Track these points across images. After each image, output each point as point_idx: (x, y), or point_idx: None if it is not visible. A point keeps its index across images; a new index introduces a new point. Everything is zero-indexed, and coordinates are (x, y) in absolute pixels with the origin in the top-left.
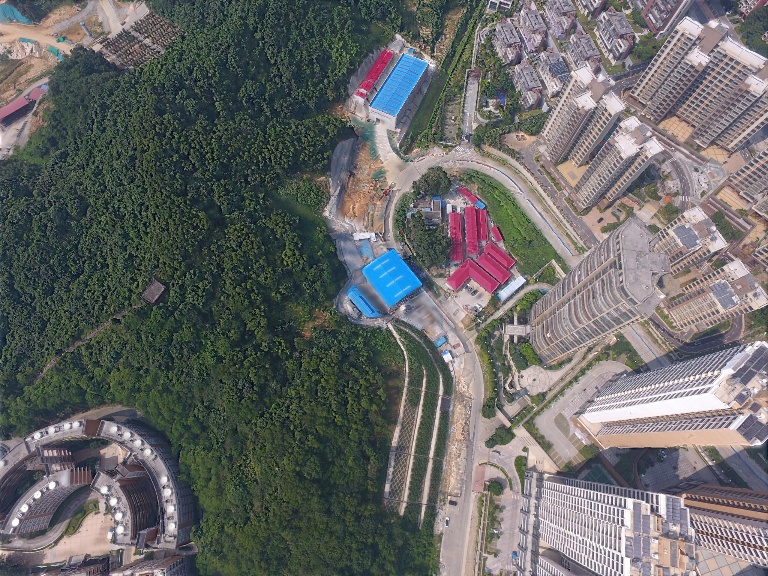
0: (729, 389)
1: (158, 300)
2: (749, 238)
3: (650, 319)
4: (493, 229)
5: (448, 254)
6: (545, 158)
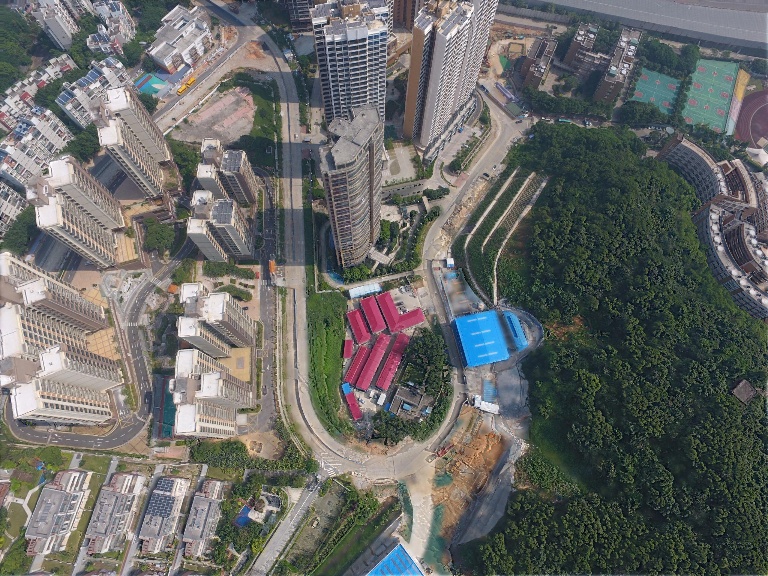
0: (372, 26)
1: None
2: (149, 209)
3: (272, 206)
4: (349, 356)
5: None
6: None
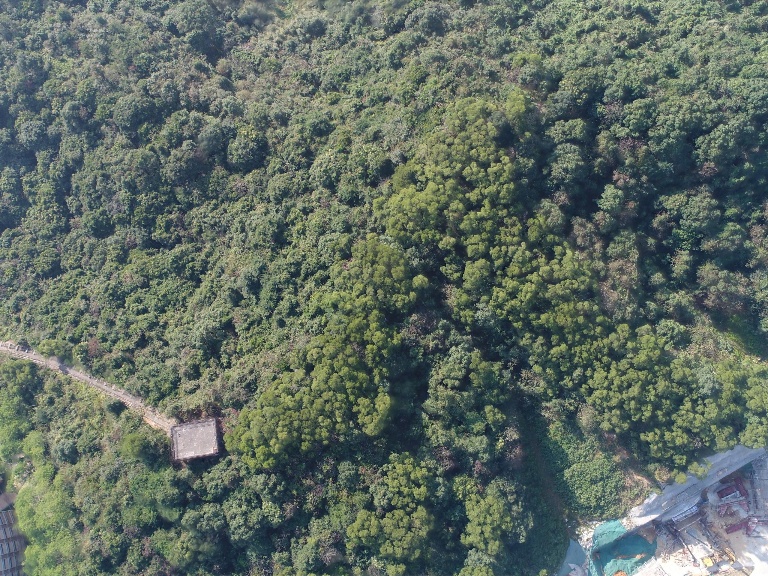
0: None
1: (189, 458)
2: None
3: None
4: None
5: None
6: None
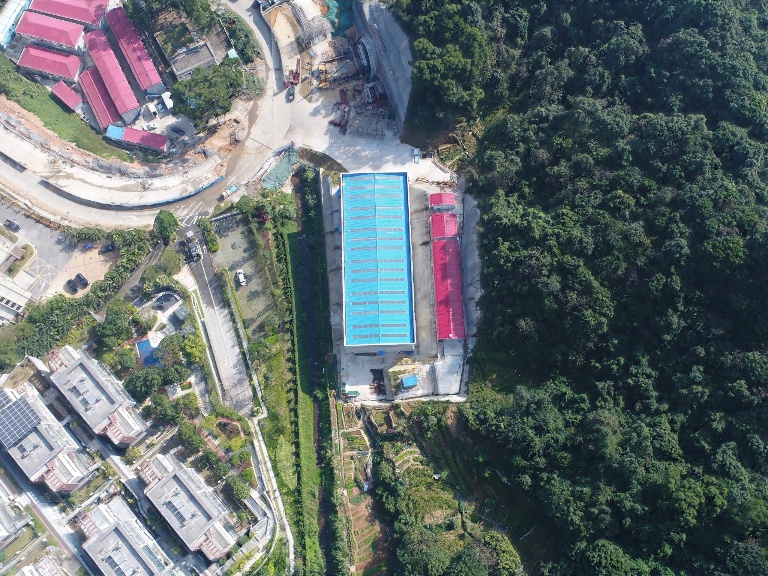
0: None
1: None
2: None
3: None
4: (76, 100)
5: (138, 27)
6: None
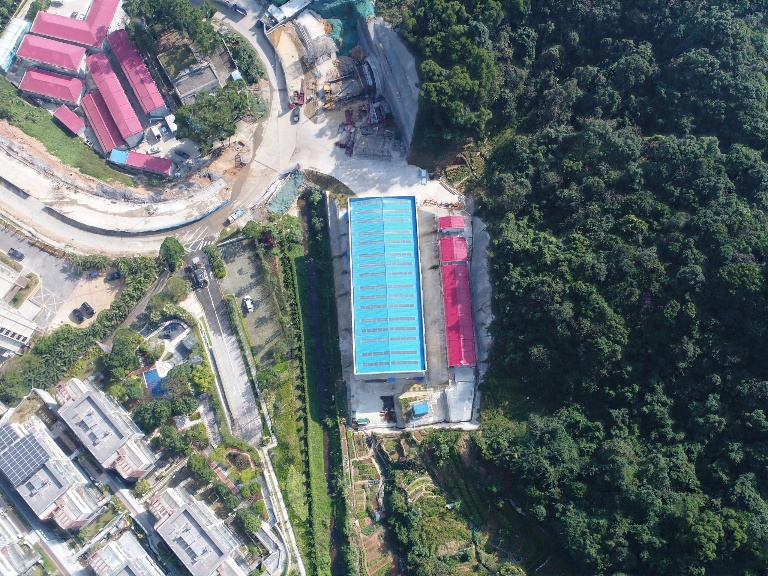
0: None
1: None
2: None
3: None
4: (79, 124)
5: (140, 48)
6: None
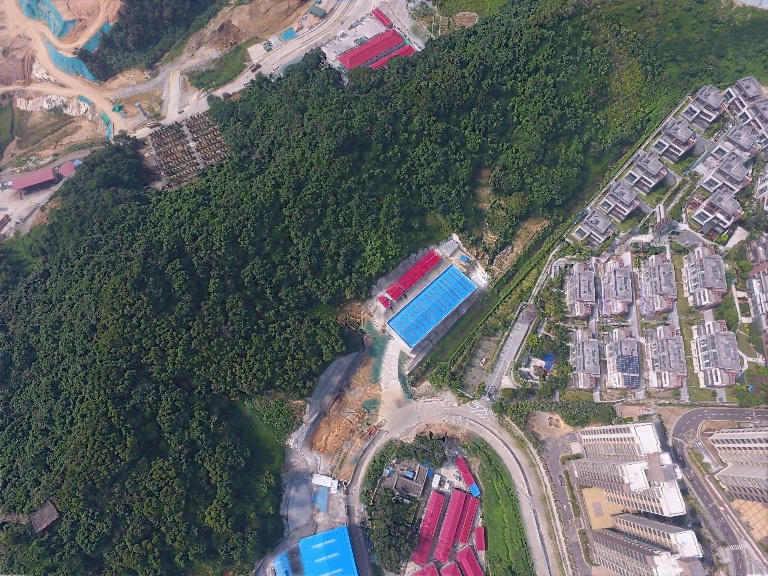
0: None
1: (46, 528)
2: None
3: None
4: (478, 530)
5: None
6: (572, 470)
